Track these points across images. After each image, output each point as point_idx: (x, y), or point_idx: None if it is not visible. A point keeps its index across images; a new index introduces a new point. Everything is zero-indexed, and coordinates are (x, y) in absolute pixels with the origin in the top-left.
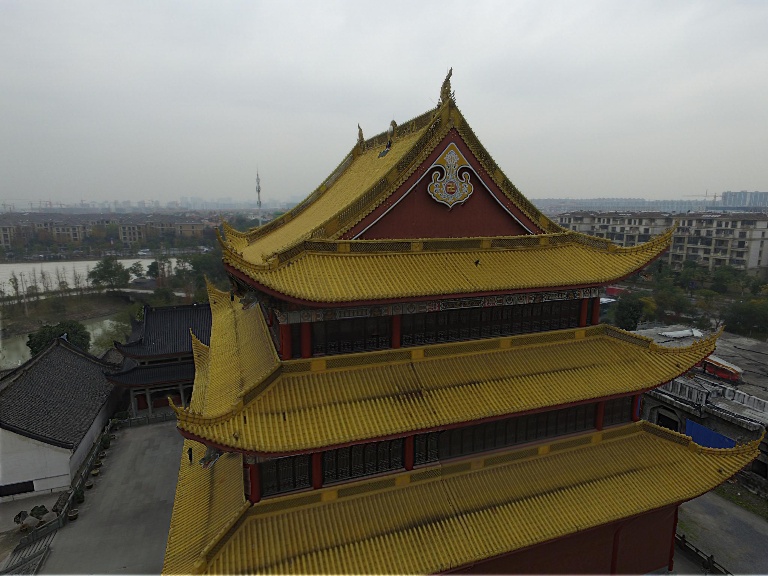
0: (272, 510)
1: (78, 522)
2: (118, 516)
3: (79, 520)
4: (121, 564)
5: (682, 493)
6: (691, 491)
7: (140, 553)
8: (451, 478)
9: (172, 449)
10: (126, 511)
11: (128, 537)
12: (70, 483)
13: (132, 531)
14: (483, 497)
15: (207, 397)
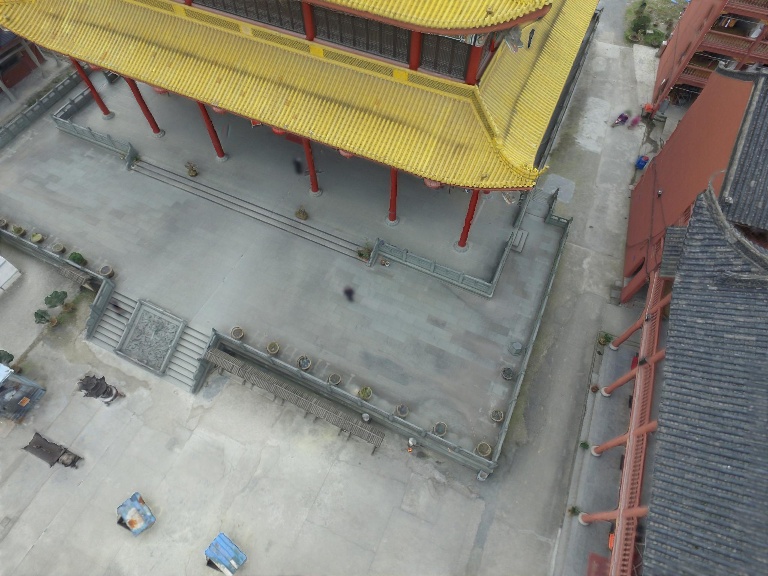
0: (482, 85)
1: (122, 273)
2: (154, 242)
3: (119, 271)
4: (234, 257)
5: None
6: None
7: (235, 241)
8: None
9: (79, 168)
10: (154, 234)
11: (200, 243)
12: (15, 268)
13: (194, 238)
14: None
15: (367, 5)
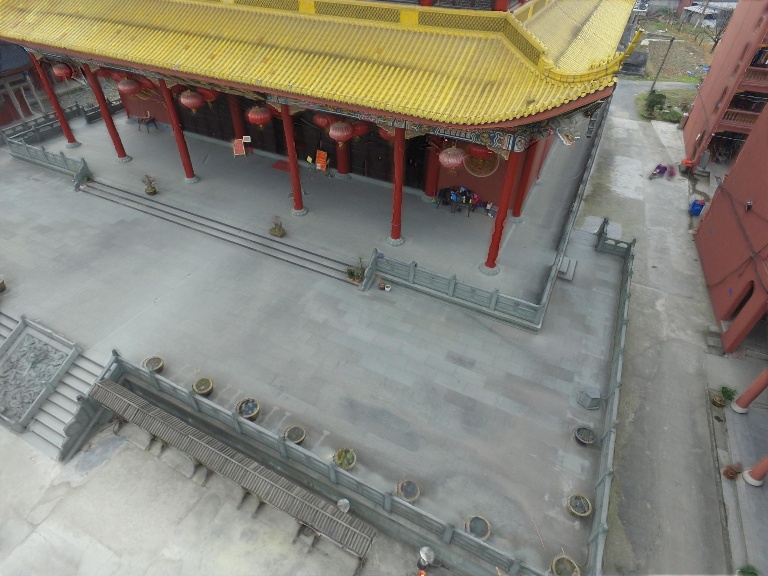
0: None
1: (17, 288)
2: (77, 257)
3: (14, 287)
4: (178, 276)
5: (629, 6)
6: (631, 5)
7: (185, 259)
8: (557, 1)
9: (17, 188)
10: (79, 249)
11: (137, 260)
12: None
13: (131, 255)
14: (579, 14)
15: None
